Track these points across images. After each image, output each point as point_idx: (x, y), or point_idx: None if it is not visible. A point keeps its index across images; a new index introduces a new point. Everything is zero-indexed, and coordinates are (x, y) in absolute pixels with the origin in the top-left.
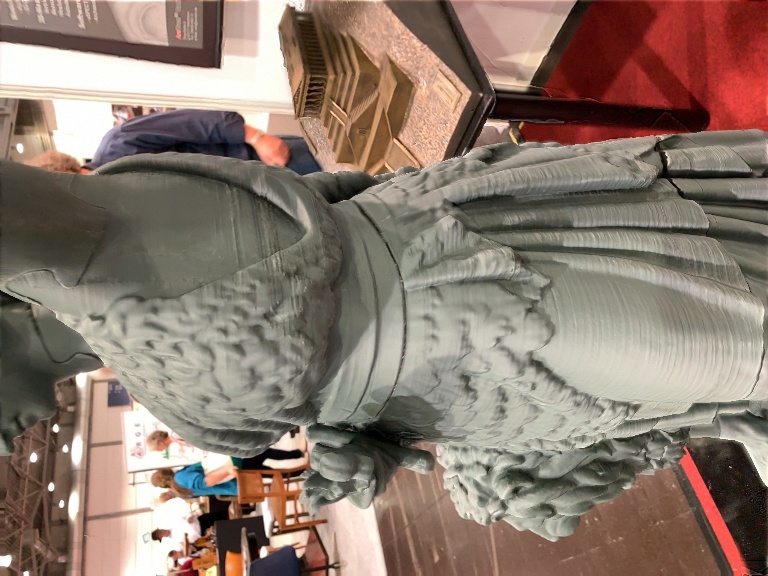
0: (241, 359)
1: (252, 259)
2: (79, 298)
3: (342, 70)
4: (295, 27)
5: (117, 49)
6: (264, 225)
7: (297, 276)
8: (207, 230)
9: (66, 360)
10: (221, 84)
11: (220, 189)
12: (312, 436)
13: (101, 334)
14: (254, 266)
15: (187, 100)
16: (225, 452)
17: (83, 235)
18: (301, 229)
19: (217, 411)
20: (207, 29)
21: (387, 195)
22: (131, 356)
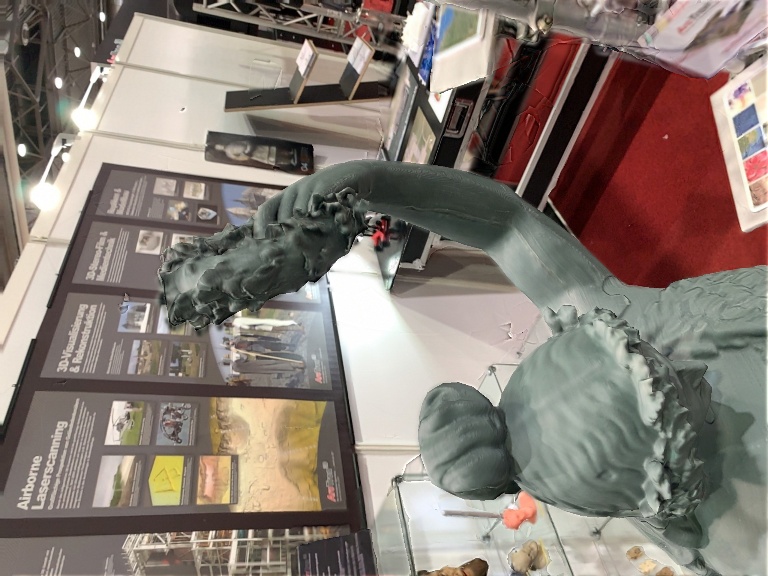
0: None
1: None
2: None
3: None
4: None
5: None
6: None
7: None
8: None
9: None
10: None
11: None
12: None
13: None
14: None
15: None
16: None
17: None
18: None
19: None
20: None
21: None
22: None
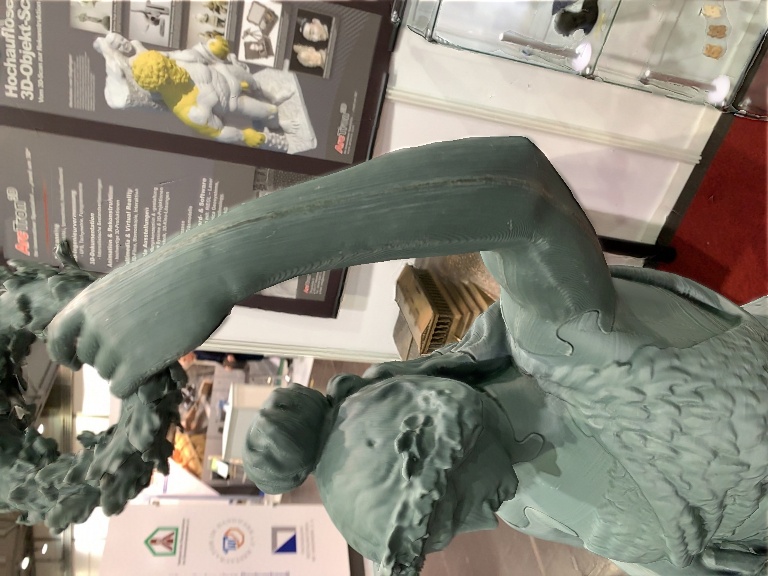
0: (757, 405)
1: (717, 330)
2: (612, 344)
3: (468, 310)
4: (417, 279)
5: (250, 301)
6: (702, 312)
7: (767, 341)
8: (666, 309)
9: (522, 440)
10: (328, 335)
11: (650, 287)
12: (717, 558)
13: (624, 381)
14: (737, 328)
15: (296, 349)
16: (679, 547)
17: (613, 290)
18: (728, 318)
19: (723, 468)
20: (331, 285)
21: (755, 310)
22: (645, 406)
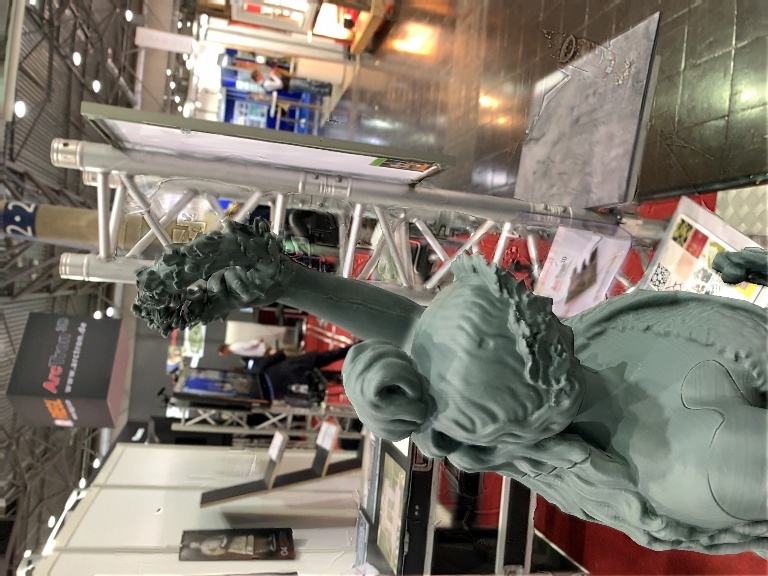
0: None
1: None
2: None
3: None
4: None
5: None
6: None
7: None
8: None
9: None
10: None
11: None
12: None
13: None
14: None
15: None
16: None
17: None
18: None
19: None
20: None
21: None
22: None
